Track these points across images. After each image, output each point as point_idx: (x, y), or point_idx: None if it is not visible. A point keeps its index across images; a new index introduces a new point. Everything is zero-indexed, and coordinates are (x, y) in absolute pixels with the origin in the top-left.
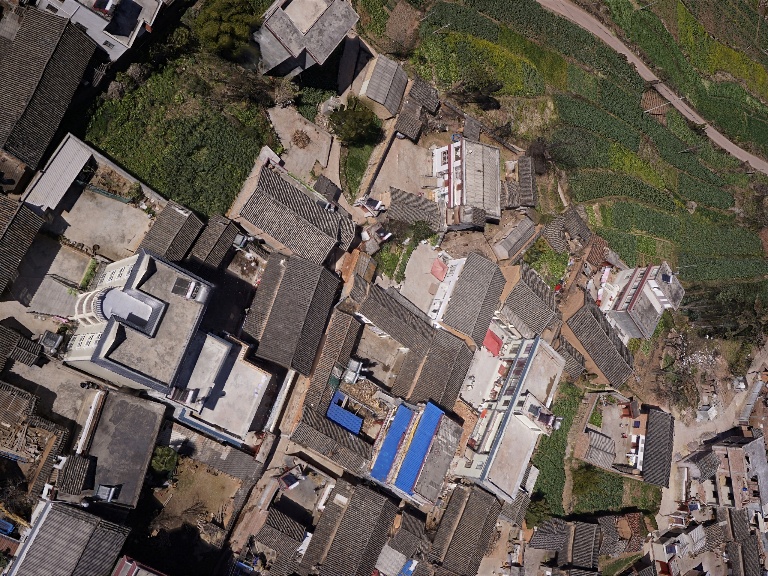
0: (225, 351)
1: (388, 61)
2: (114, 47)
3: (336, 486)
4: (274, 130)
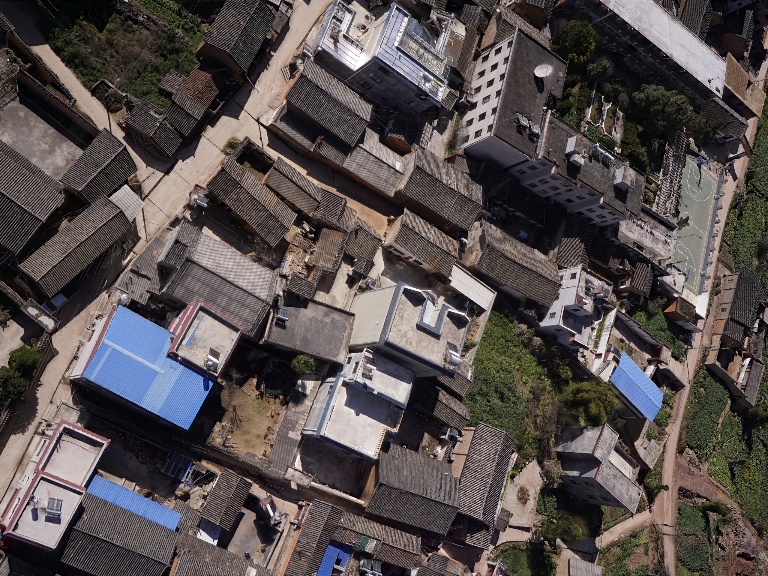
0: (401, 401)
1: (600, 575)
2: (553, 319)
3: (263, 568)
4: (524, 467)
